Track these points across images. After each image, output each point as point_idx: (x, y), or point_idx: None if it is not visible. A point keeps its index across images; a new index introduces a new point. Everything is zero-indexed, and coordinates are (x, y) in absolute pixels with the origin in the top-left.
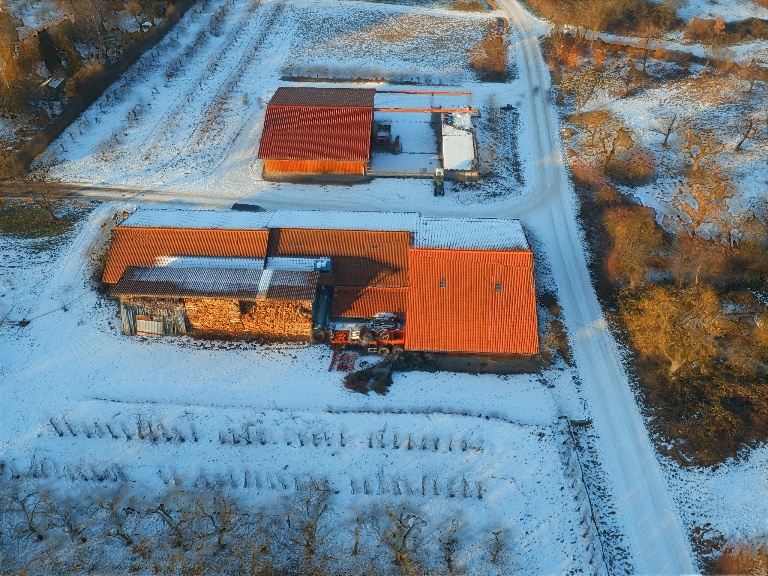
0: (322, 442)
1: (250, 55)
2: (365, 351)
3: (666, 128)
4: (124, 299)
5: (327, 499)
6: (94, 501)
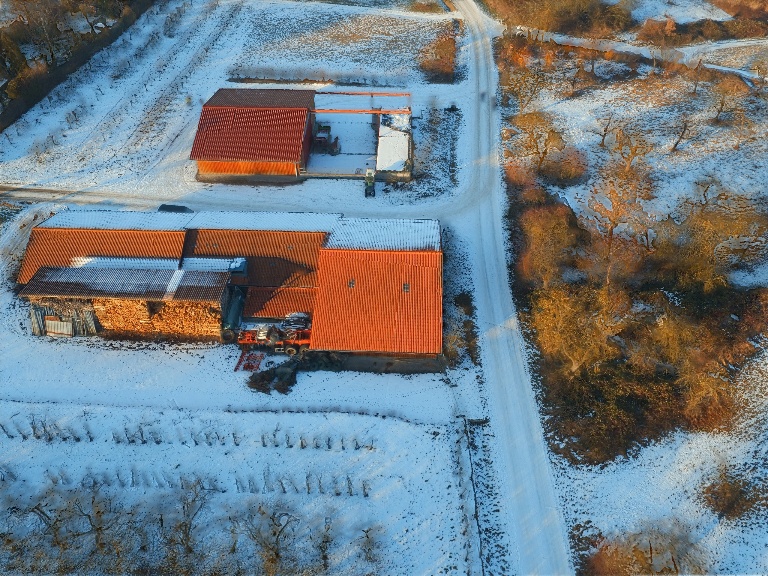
0: (217, 441)
1: (201, 56)
2: (273, 351)
3: (607, 129)
4: (33, 300)
5: (212, 498)
6: None
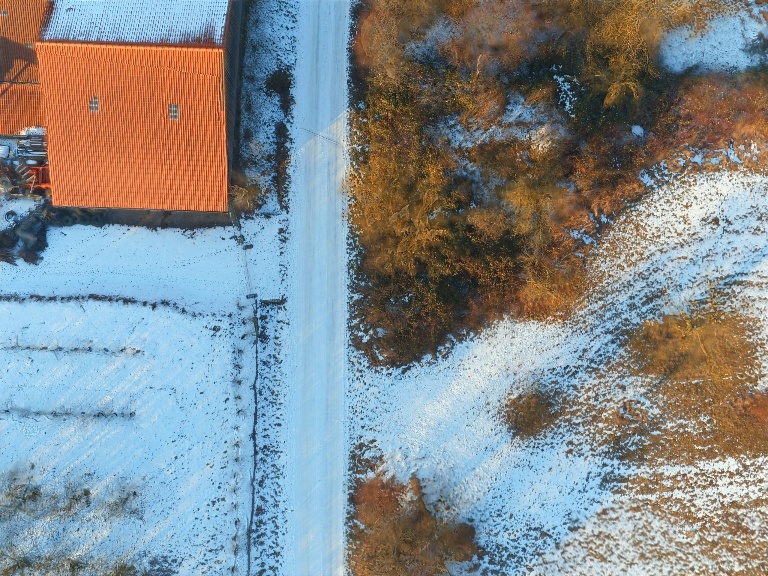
0: None
1: None
2: None
3: None
4: None
5: None
6: None
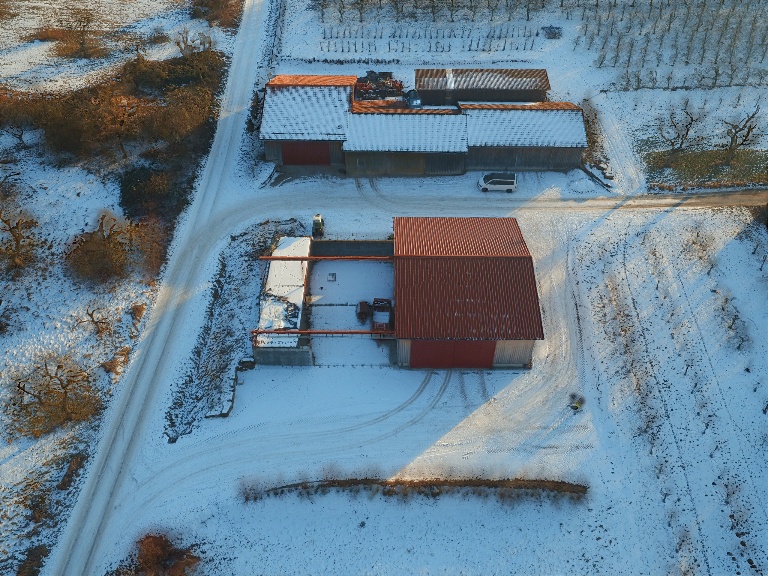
0: None
1: None
2: None
3: None
4: None
5: None
6: (496, 30)
